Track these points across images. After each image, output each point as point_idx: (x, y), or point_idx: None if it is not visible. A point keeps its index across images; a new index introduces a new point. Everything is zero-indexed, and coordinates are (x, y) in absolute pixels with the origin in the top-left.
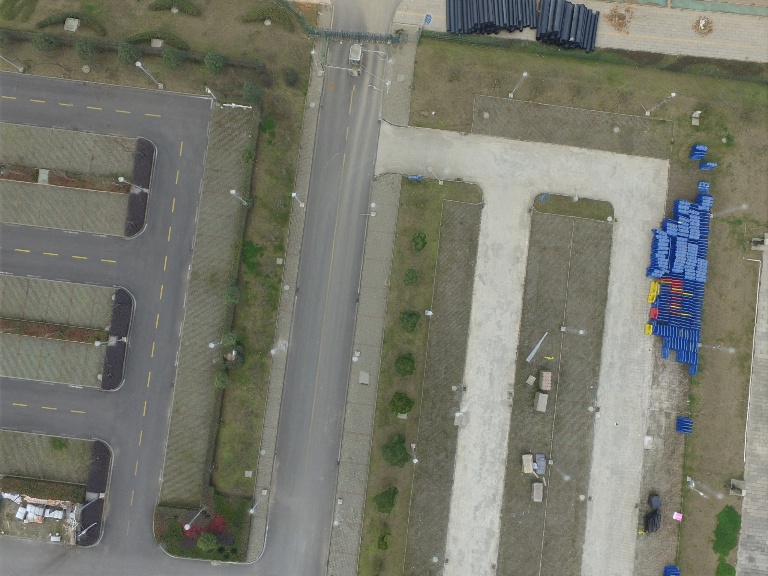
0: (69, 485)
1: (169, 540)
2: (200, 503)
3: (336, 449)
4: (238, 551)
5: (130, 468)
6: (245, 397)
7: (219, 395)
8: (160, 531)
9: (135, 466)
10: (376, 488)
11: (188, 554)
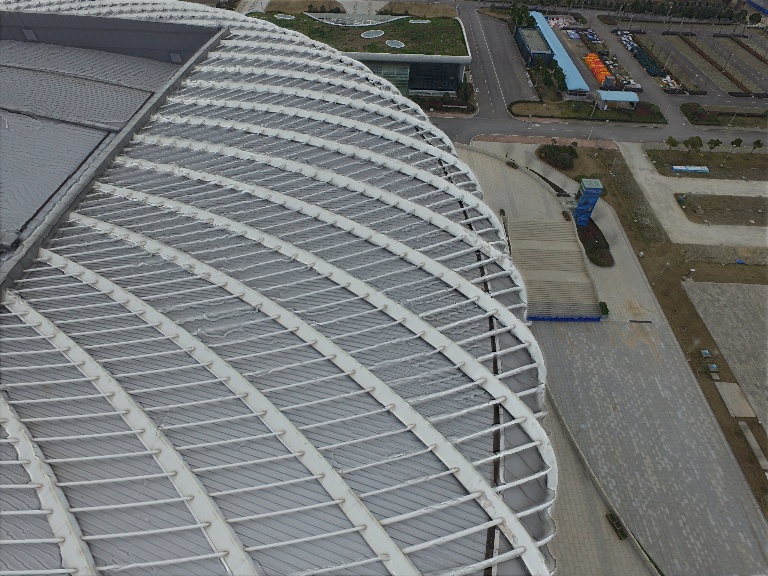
0: (686, 87)
1: (686, 106)
2: (710, 111)
3: (766, 146)
4: (697, 121)
5: (703, 99)
6: (762, 123)
7: (759, 114)
8: (689, 104)
9: (705, 100)
10: (762, 156)
11: (685, 110)
